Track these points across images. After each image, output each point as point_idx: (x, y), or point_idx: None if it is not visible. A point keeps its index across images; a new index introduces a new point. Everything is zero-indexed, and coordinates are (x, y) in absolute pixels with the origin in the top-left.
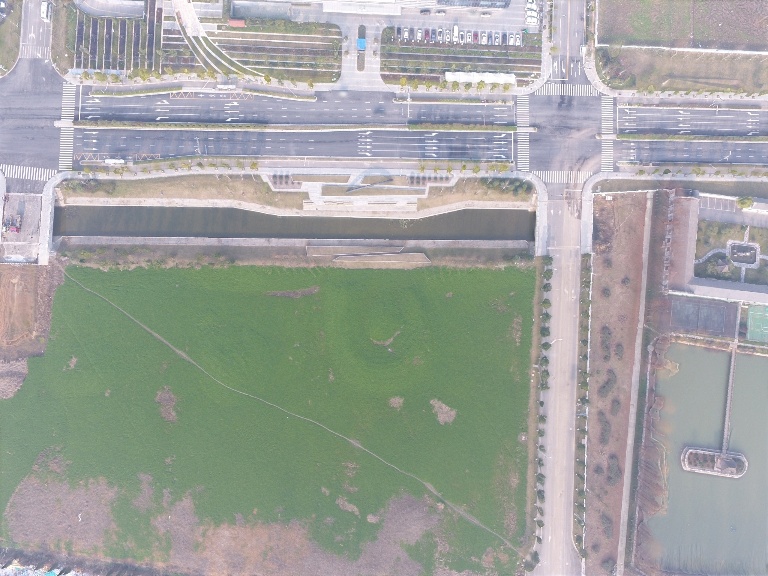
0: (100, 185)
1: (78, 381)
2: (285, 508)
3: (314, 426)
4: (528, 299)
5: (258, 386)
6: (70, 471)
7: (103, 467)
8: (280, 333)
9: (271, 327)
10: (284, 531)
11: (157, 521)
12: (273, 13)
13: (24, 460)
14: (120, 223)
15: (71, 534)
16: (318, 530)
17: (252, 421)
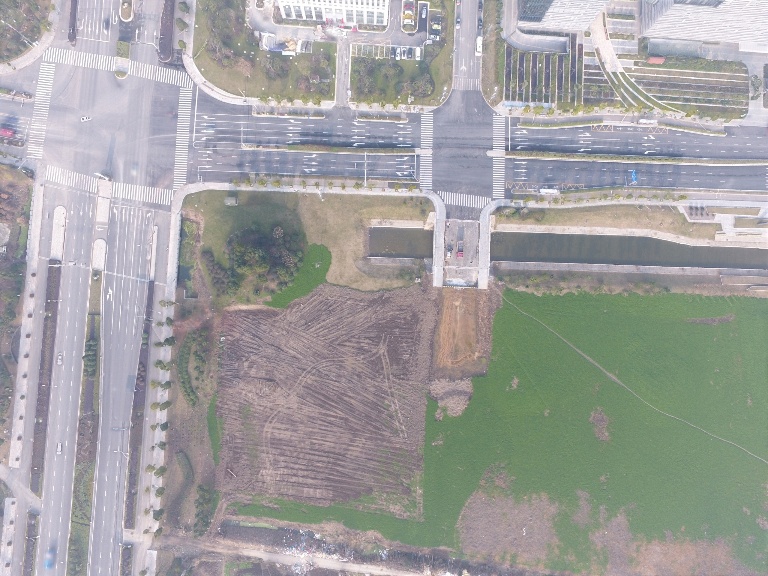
0: (532, 213)
1: (521, 401)
2: (711, 526)
3: (735, 448)
4: None
5: (684, 409)
6: (514, 487)
7: (544, 483)
8: (702, 359)
9: (693, 353)
10: (710, 548)
11: (595, 536)
12: (683, 51)
13: (473, 475)
14: (543, 249)
15: (517, 547)
16: (741, 548)
17: (679, 442)
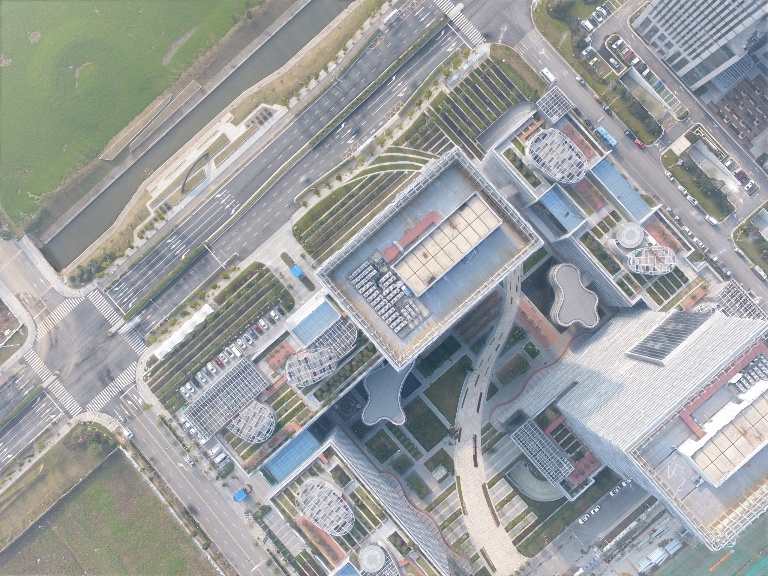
0: None
1: None
2: None
3: None
4: (3, 198)
5: None
6: None
7: None
8: (161, 8)
9: (171, 6)
10: None
11: None
12: None
13: None
14: None
15: None
16: None
17: None
